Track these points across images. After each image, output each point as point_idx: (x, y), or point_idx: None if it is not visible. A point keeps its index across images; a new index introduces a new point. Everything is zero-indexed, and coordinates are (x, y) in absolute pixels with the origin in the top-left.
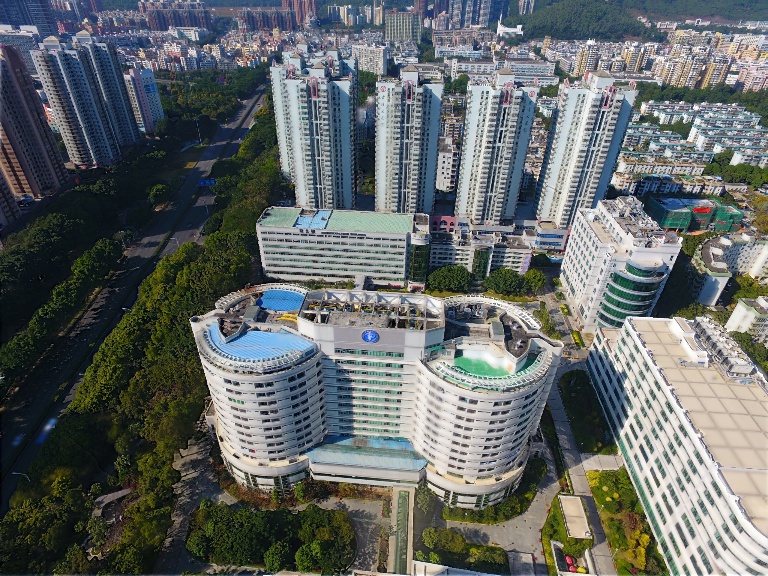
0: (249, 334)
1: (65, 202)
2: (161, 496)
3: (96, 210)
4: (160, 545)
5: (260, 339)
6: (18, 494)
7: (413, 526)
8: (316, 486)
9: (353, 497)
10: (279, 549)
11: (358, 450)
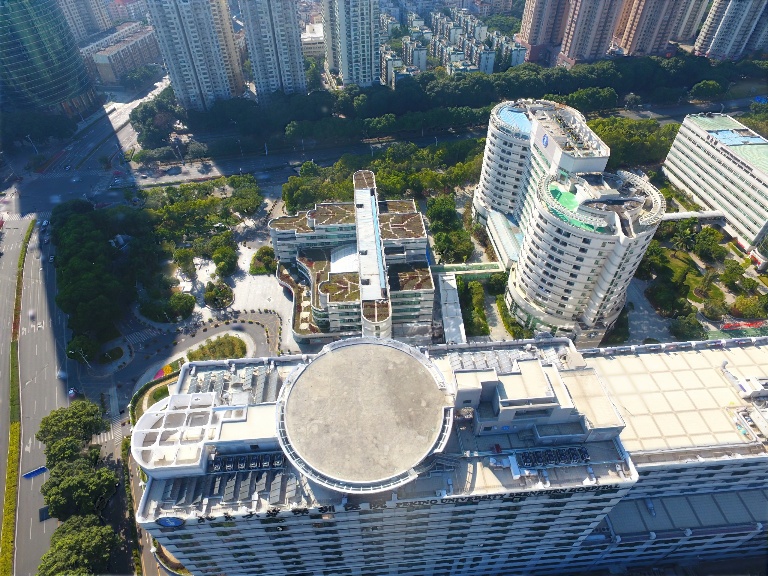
0: (520, 114)
1: (634, 62)
2: (447, 180)
3: (643, 75)
4: (429, 197)
5: (519, 117)
6: (429, 145)
7: (483, 286)
8: (483, 233)
9: (489, 257)
10: (439, 224)
11: (508, 228)
